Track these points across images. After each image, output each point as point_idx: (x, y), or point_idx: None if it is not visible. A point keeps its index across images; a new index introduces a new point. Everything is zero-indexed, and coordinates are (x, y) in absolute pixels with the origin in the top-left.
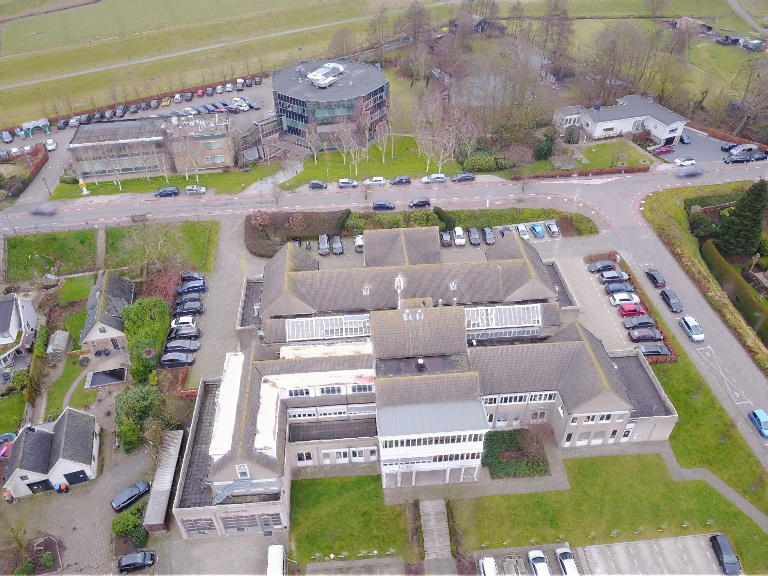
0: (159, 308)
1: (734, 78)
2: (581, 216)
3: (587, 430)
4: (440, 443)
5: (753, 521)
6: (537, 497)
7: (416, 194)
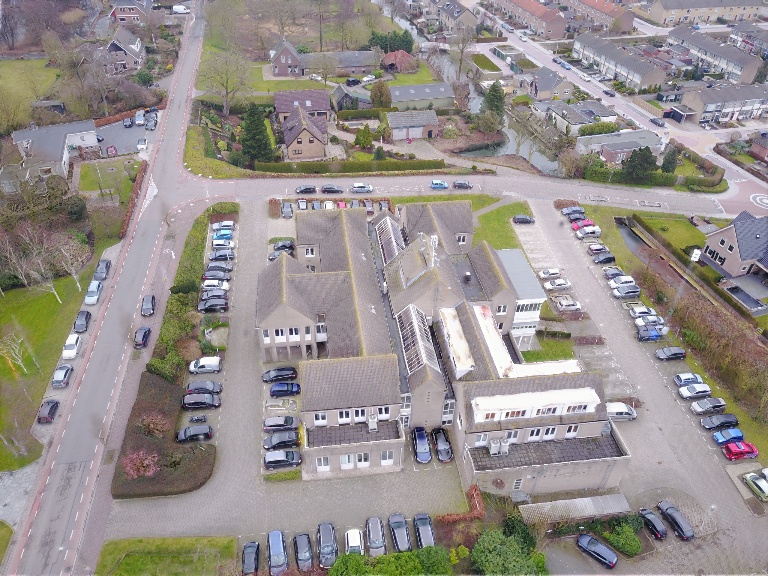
0: (356, 557)
1: (66, 74)
2: (217, 205)
3: None
4: None
5: (501, 207)
6: None
7: (121, 310)
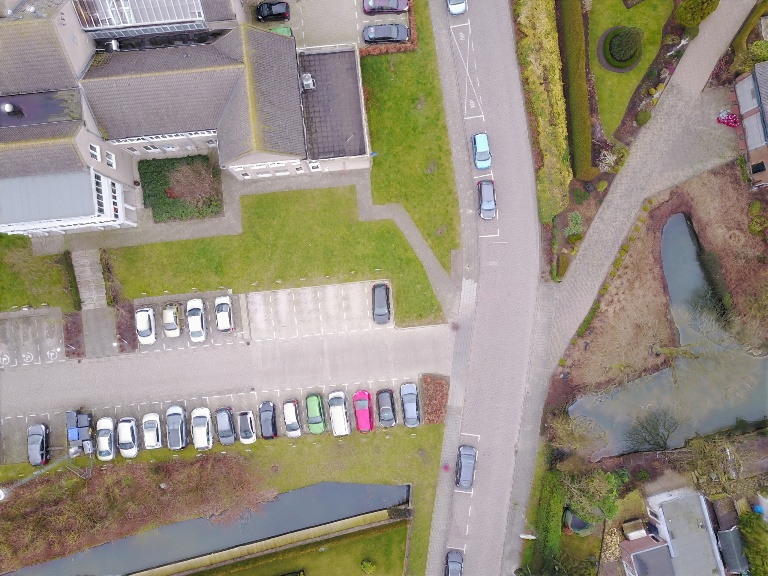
0: None
1: None
2: None
3: (261, 171)
4: (50, 221)
5: (423, 268)
6: (203, 243)
7: None
